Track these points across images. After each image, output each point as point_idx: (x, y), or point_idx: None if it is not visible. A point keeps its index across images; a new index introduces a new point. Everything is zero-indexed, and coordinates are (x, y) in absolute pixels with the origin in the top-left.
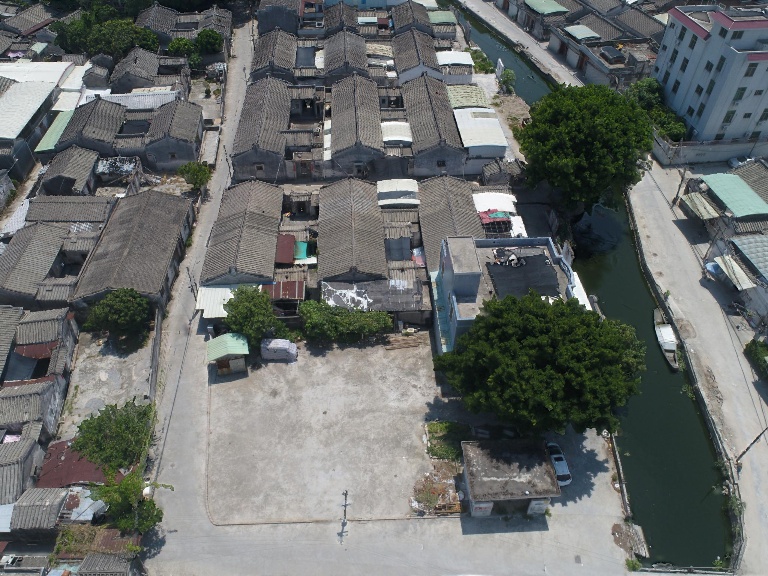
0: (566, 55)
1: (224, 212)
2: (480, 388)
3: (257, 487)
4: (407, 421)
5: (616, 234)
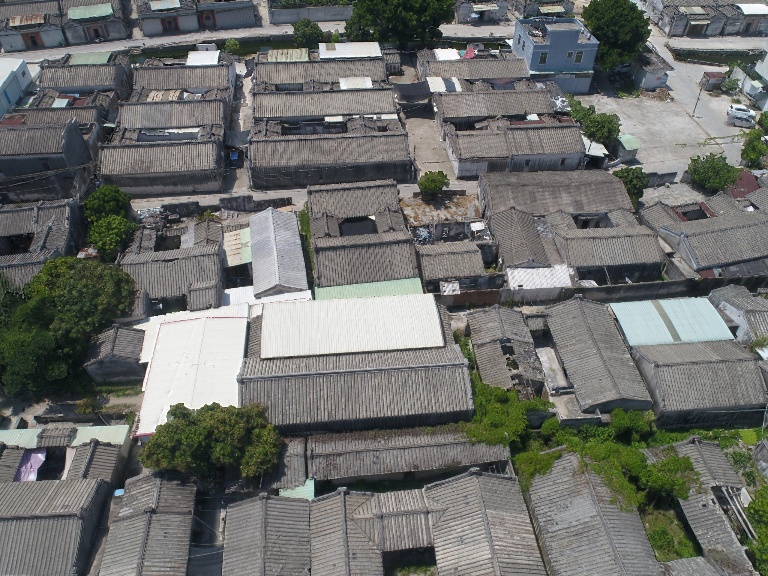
0: (178, 27)
1: (495, 153)
2: (628, 50)
3: (694, 141)
4: (623, 103)
5: (430, 46)
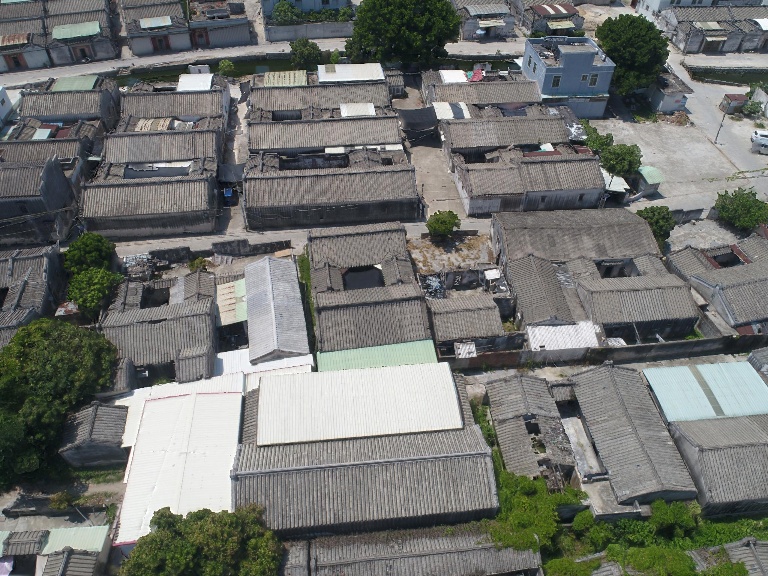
0: (169, 45)
1: (509, 189)
2: (646, 72)
3: (718, 171)
4: (640, 128)
5: (434, 64)
